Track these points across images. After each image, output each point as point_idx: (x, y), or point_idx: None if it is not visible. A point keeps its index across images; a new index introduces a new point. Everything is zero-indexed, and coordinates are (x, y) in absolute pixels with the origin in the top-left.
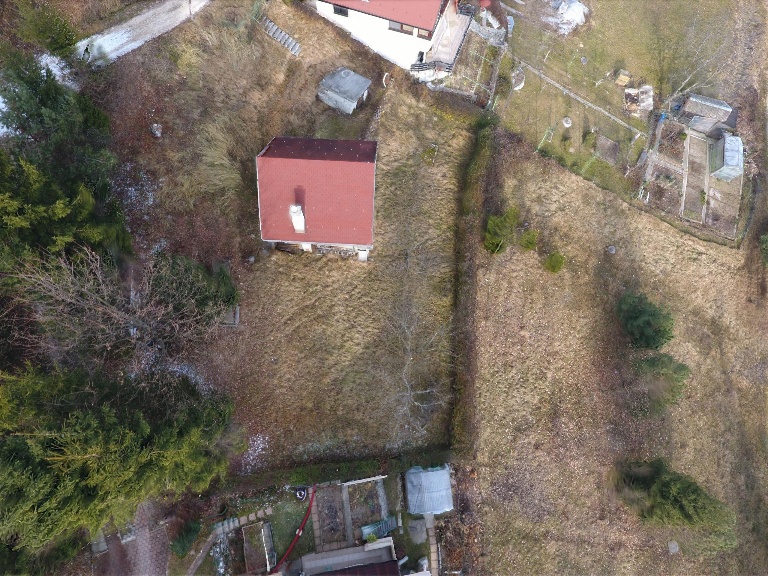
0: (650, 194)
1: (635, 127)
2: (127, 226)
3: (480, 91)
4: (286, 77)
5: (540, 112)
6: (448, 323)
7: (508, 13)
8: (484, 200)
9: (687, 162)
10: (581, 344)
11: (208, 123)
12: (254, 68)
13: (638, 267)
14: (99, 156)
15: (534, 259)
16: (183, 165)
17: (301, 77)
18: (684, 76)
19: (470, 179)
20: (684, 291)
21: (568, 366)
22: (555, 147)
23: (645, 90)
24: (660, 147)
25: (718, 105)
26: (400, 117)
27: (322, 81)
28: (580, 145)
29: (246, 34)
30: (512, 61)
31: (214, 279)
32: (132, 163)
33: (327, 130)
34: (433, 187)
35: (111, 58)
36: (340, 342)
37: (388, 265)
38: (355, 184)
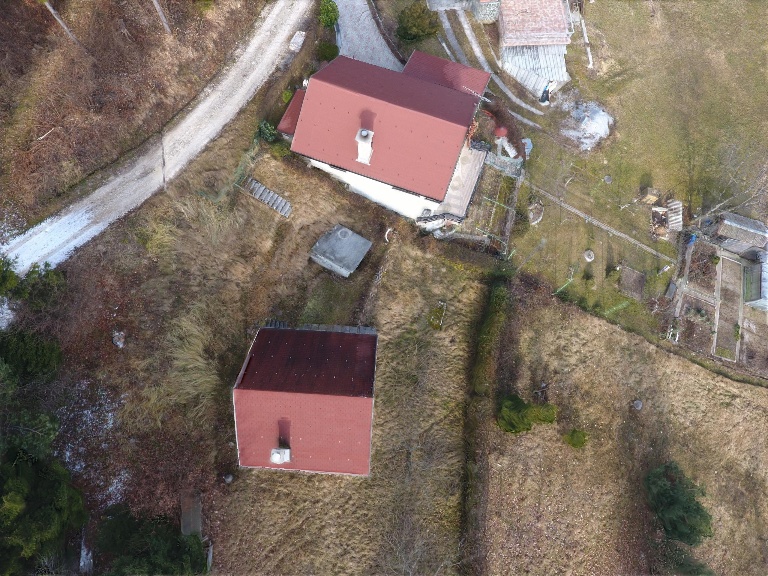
0: (679, 331)
1: (663, 253)
2: (81, 460)
3: (494, 232)
4: (274, 242)
5: (560, 247)
6: (455, 528)
7: (525, 128)
8: (497, 366)
9: (719, 289)
10: (604, 527)
11: (181, 316)
12: (237, 237)
13: (666, 420)
14: (37, 423)
15: (552, 429)
16: (150, 374)
17: (291, 241)
18: (716, 186)
19: (482, 352)
20: (716, 443)
21: (589, 558)
22: (576, 286)
23: (674, 207)
24: (690, 274)
25: (755, 230)
26: (404, 273)
27: (315, 245)
28: (603, 280)
29: (228, 202)
30: (529, 190)
31: (176, 567)
32: (89, 379)
33: (321, 297)
34: (440, 356)
35: (67, 250)
36: (330, 574)
37: (388, 463)
38: (349, 418)
